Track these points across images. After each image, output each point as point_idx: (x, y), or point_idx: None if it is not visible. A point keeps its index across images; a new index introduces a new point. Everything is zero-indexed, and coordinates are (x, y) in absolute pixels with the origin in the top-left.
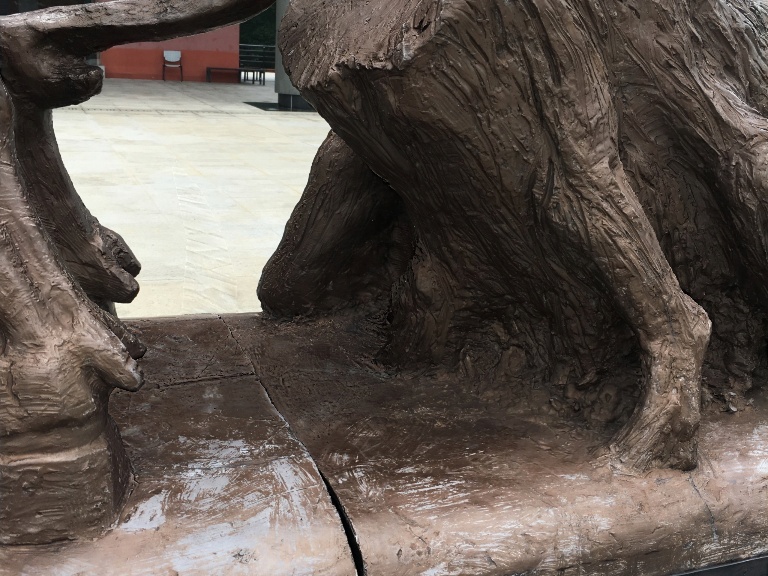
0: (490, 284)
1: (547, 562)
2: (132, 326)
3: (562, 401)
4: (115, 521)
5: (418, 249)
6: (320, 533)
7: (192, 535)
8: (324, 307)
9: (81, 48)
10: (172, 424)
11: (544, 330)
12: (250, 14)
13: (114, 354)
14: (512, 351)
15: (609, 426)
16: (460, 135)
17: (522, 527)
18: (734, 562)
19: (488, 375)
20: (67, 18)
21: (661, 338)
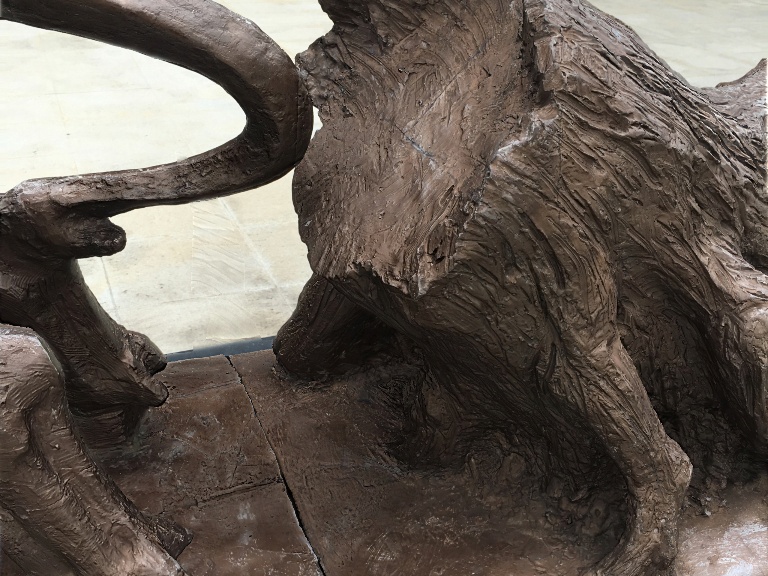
0: (494, 413)
1: None
2: None
3: (557, 514)
4: None
5: (428, 376)
6: None
7: None
8: (338, 372)
9: (104, 213)
10: (215, 562)
11: (542, 446)
12: (266, 182)
13: None
14: (513, 457)
15: (597, 540)
16: (470, 334)
17: None
18: None
19: (491, 478)
20: (89, 191)
21: (647, 485)
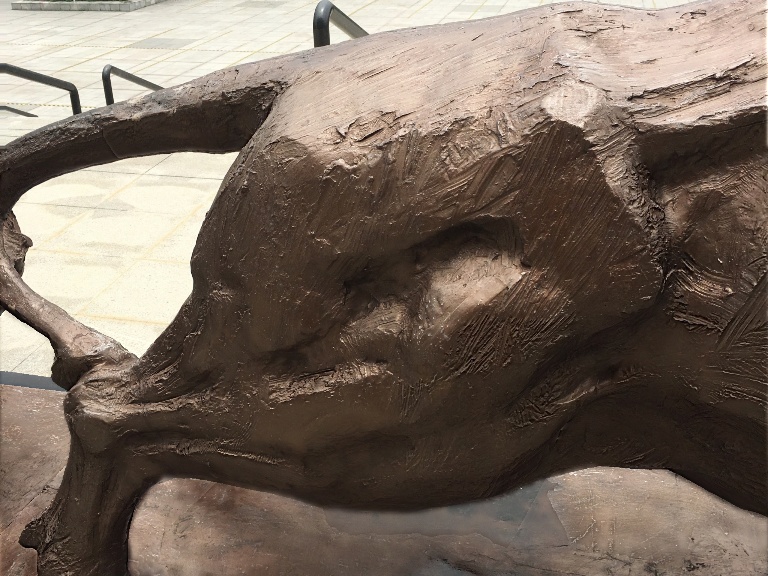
0: None
1: None
2: None
3: None
4: None
5: None
6: None
7: None
8: None
9: None
10: None
11: None
12: None
13: None
14: None
15: None
16: None
17: None
18: None
19: None
20: None
21: None
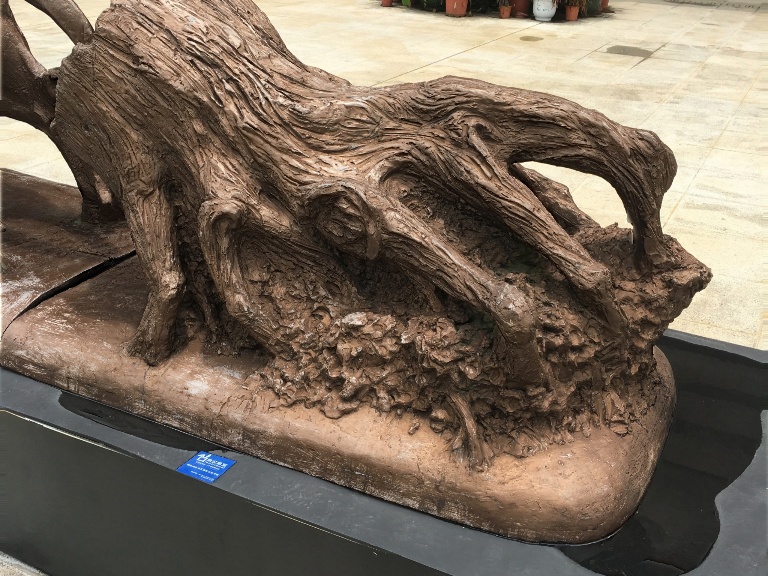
0: None
1: (63, 372)
2: None
3: None
4: None
5: None
6: (2, 321)
7: None
8: None
9: None
10: None
11: None
12: None
13: None
14: None
15: None
16: (88, 164)
17: (61, 352)
18: (150, 420)
19: None
20: None
21: (151, 293)
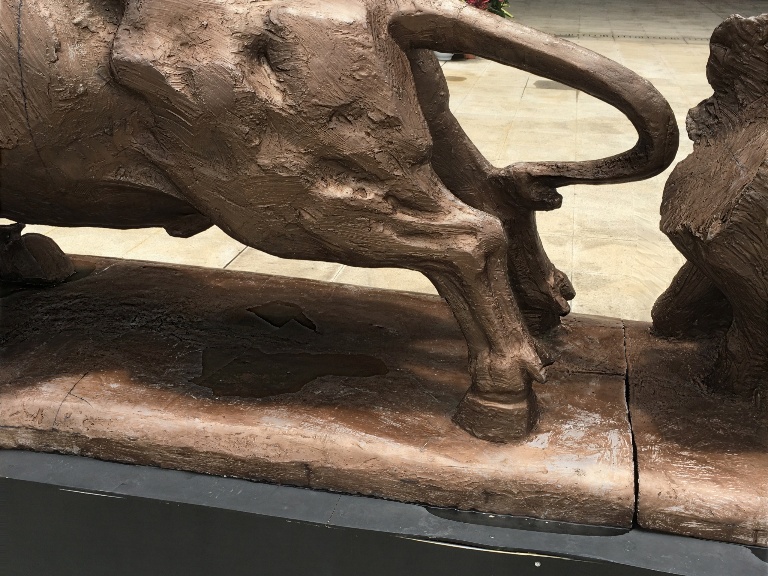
0: None
1: (747, 524)
2: (568, 325)
3: None
4: (526, 440)
5: (733, 324)
6: (621, 473)
7: (558, 456)
8: (690, 335)
9: (553, 184)
10: (567, 397)
11: None
12: (646, 177)
13: (535, 366)
14: None
15: None
16: (744, 277)
17: (736, 501)
18: None
19: None
20: (547, 170)
21: None
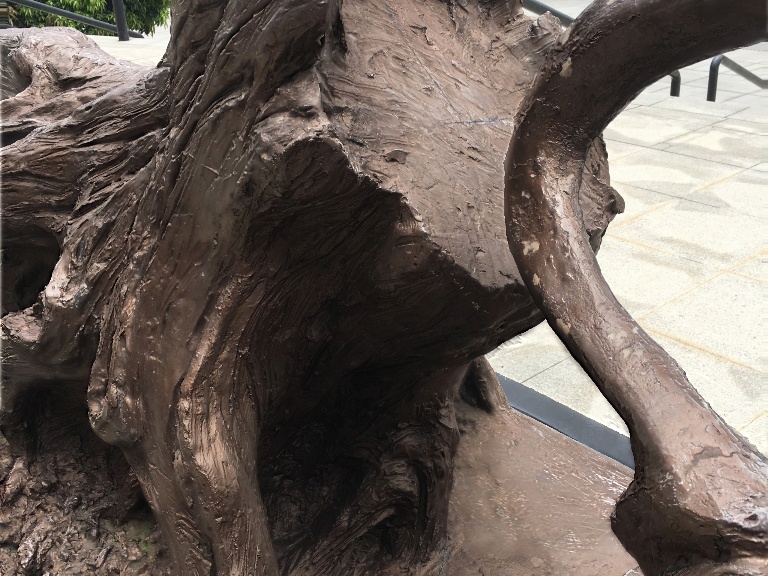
0: None
1: None
2: None
3: None
4: None
5: (443, 409)
6: None
7: None
8: None
9: None
10: None
11: None
12: None
13: None
14: None
15: None
16: None
17: None
18: None
19: None
20: None
21: None
